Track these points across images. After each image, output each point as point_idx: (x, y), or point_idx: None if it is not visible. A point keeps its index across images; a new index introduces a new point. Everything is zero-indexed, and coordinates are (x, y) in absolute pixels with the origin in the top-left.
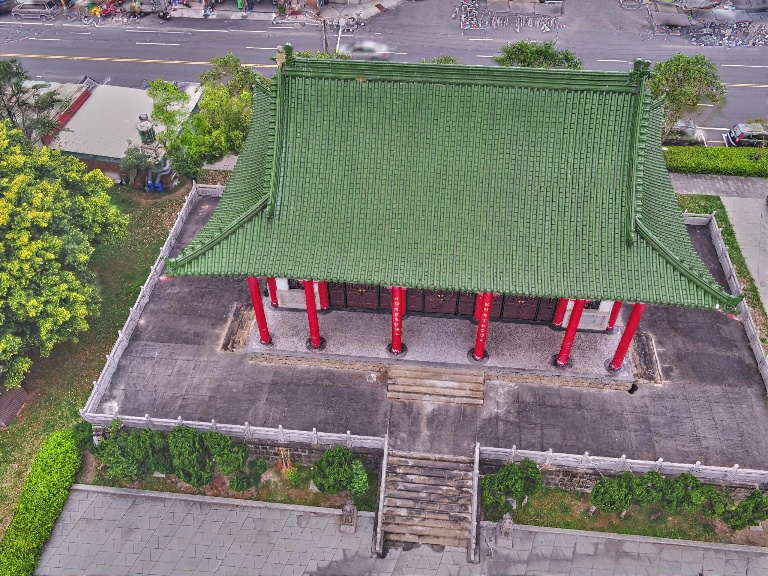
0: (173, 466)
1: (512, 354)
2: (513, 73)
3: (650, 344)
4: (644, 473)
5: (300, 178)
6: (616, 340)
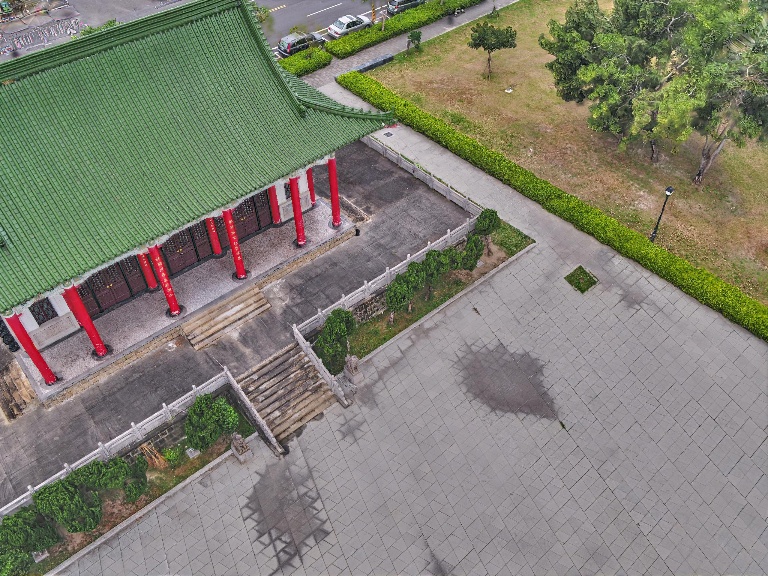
0: (55, 531)
1: (264, 259)
2: (141, 24)
3: (344, 201)
4: (404, 273)
5: (6, 197)
6: (324, 208)
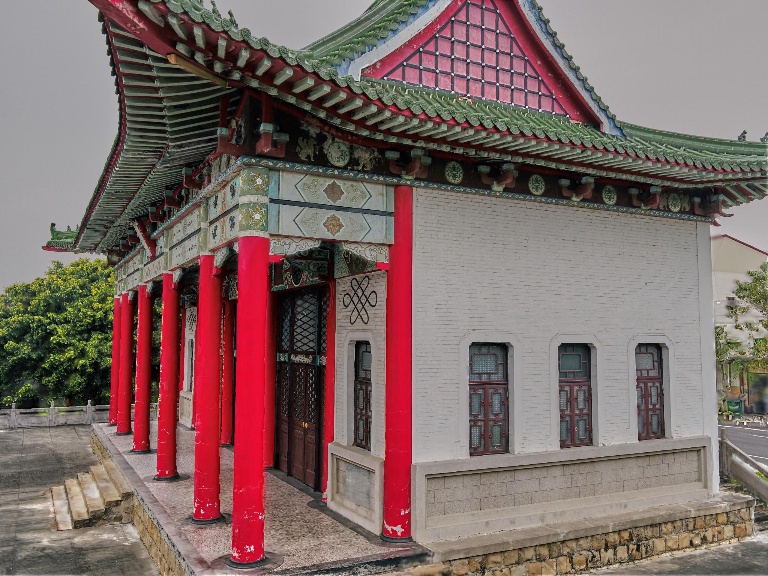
0: None
1: None
2: None
3: None
4: None
5: None
6: (358, 549)
